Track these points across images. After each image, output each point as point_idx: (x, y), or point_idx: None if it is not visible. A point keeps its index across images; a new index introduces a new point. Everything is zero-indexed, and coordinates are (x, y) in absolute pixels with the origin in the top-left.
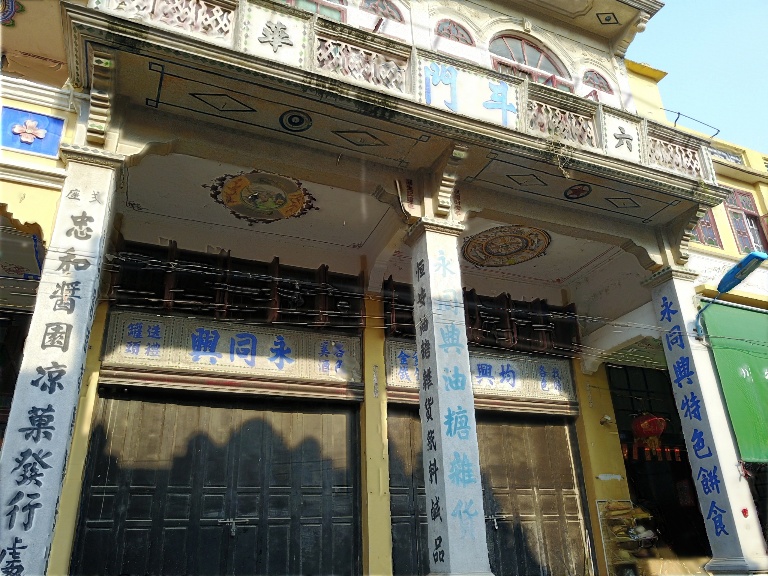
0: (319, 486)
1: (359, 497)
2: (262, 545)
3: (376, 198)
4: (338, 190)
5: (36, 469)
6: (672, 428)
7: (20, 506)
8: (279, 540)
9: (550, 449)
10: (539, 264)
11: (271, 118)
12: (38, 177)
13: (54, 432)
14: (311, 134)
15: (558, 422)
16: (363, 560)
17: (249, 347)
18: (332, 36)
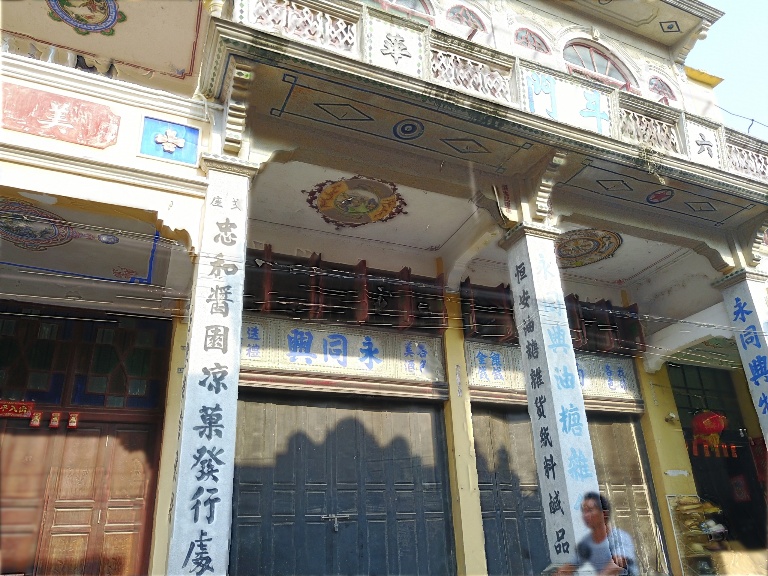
0: (411, 483)
1: (448, 493)
2: (363, 540)
3: (473, 203)
4: (431, 195)
5: (212, 465)
6: (729, 425)
7: (202, 500)
8: (378, 535)
9: (618, 446)
10: (605, 266)
11: (386, 127)
12: (183, 185)
13: (224, 430)
14: (420, 142)
15: (624, 420)
16: (456, 554)
17: (340, 348)
18: (443, 47)
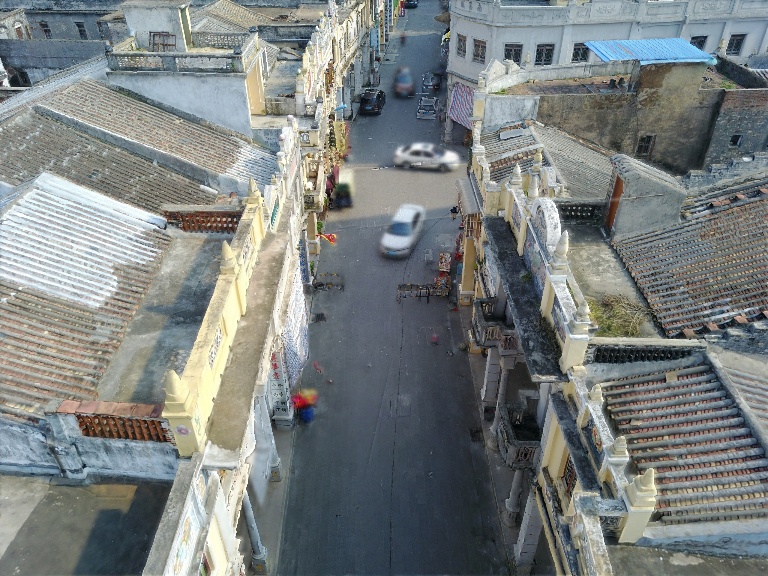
0: None
1: None
2: None
3: None
4: None
5: None
6: None
7: None
8: None
9: None
10: None
11: None
12: None
13: None
14: None
15: None
16: None
17: None
18: None
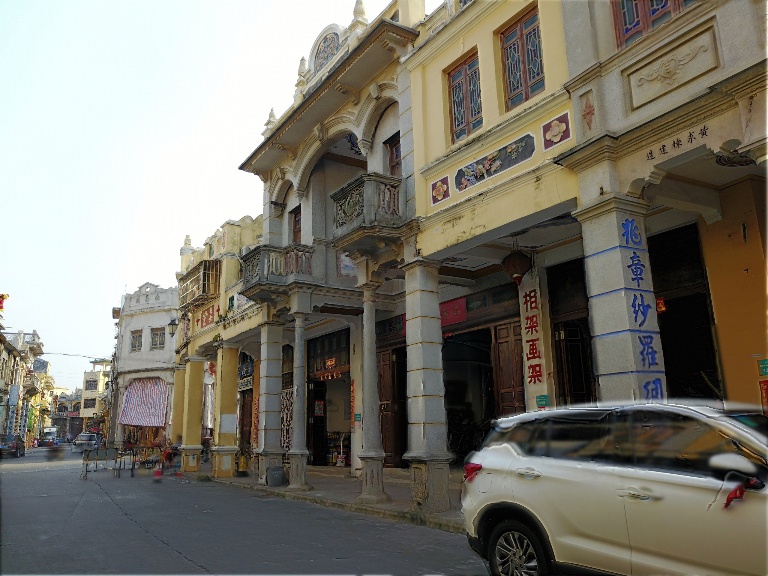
0: None
1: None
2: None
3: None
4: None
5: None
6: None
7: None
8: None
9: None
10: None
11: None
12: None
13: None
14: None
15: None
16: None
17: None
18: None
